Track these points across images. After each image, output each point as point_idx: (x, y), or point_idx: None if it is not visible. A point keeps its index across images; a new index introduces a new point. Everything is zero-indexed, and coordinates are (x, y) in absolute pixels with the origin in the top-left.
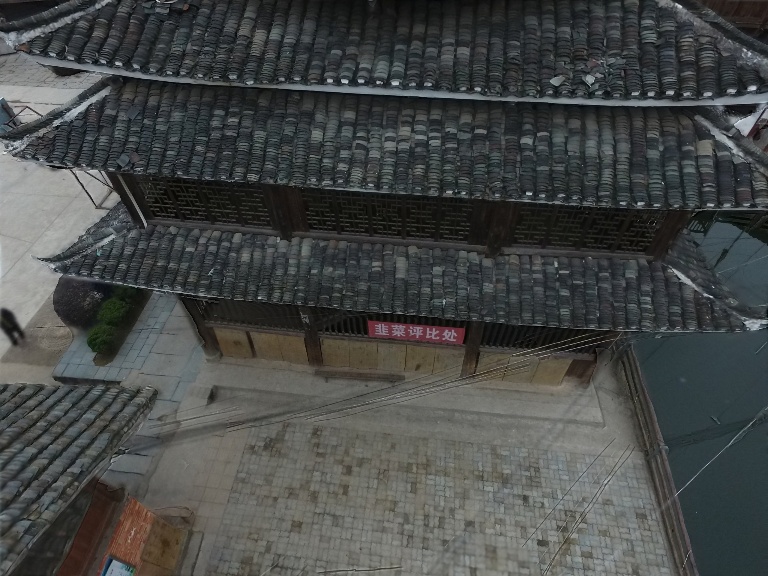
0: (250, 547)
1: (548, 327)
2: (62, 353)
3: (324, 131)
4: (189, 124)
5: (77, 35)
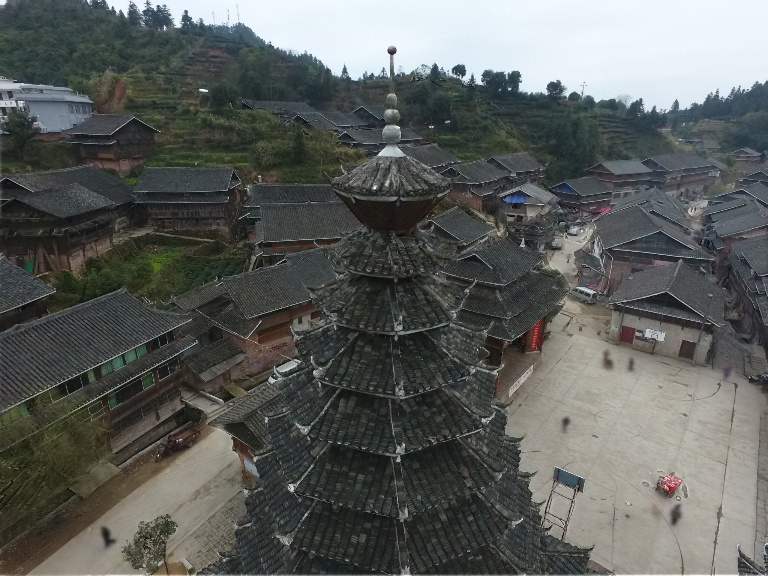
0: None
1: None
2: None
3: None
4: None
5: None
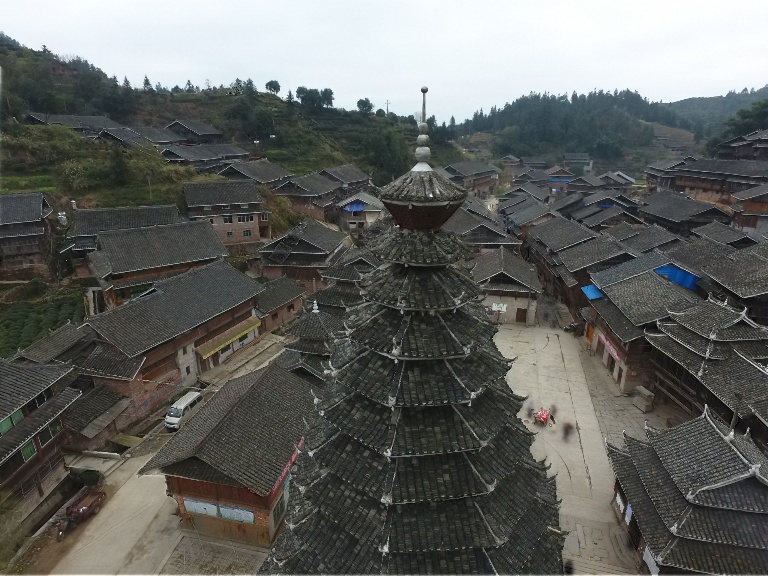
0: (256, 569)
1: None
2: None
3: None
4: None
5: None
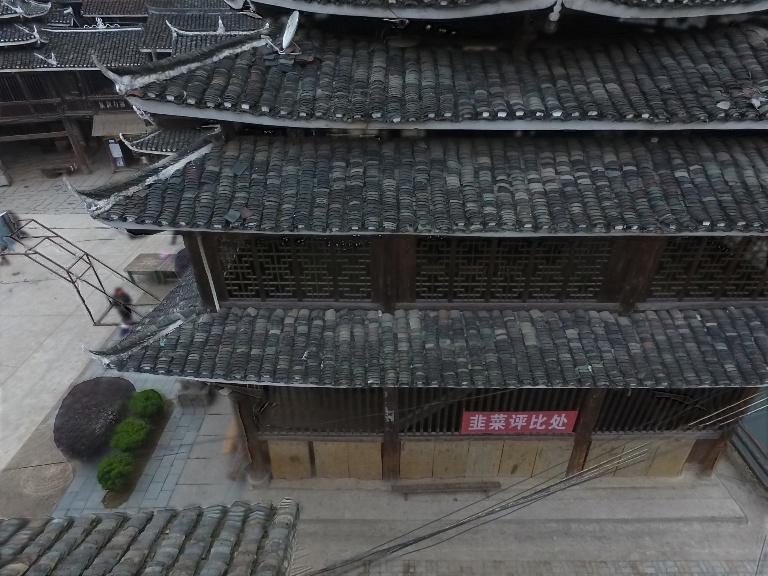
0: None
1: (715, 388)
2: (53, 498)
3: (460, 177)
4: (306, 176)
5: (196, 82)
